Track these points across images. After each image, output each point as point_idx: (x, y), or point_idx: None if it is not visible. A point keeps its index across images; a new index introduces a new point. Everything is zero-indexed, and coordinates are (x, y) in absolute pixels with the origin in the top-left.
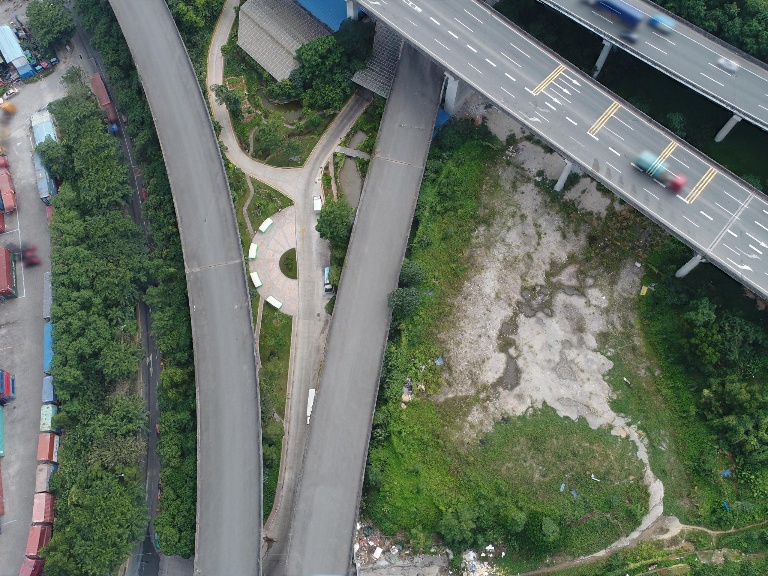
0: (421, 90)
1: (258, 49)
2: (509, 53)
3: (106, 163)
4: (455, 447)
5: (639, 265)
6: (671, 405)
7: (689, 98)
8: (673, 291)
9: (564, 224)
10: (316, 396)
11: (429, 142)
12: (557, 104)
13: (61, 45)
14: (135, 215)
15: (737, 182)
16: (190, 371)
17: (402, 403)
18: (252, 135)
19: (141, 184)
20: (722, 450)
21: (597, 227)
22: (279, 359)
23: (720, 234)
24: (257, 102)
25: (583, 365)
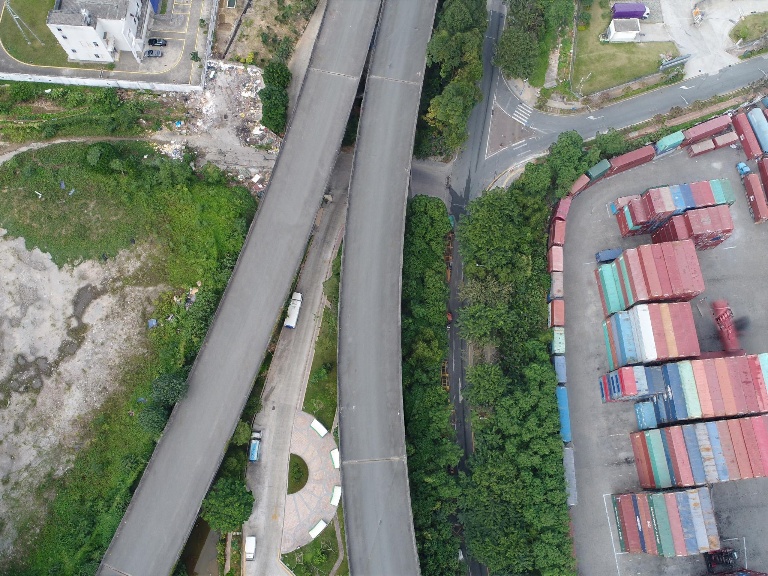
0: None
1: None
2: None
3: None
4: None
5: None
6: None
7: None
8: None
9: None
10: (284, 304)
11: None
12: None
13: None
14: None
15: None
16: (412, 356)
17: None
18: None
19: None
20: None
21: None
22: None
23: None
24: None
25: (8, 299)
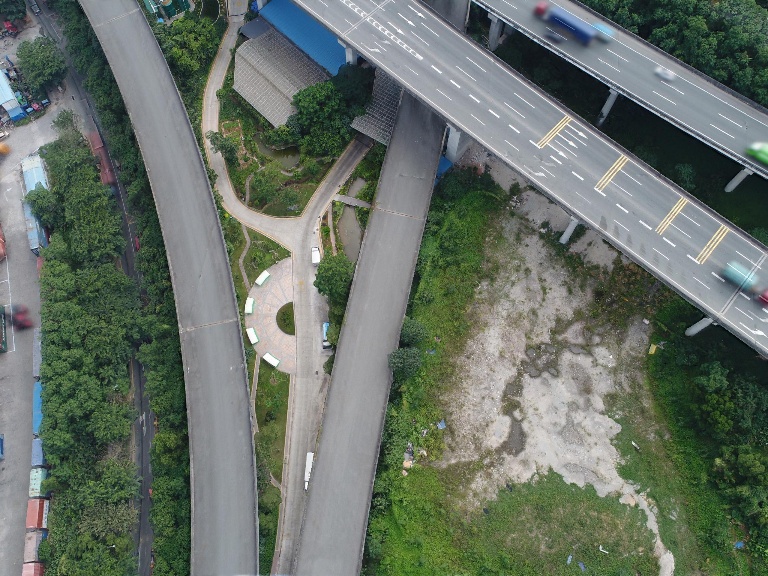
0: (422, 138)
1: (254, 93)
2: (513, 103)
3: (98, 214)
4: (458, 517)
5: (647, 322)
6: (681, 471)
7: (698, 146)
8: (683, 352)
9: (570, 278)
10: (314, 463)
11: (430, 193)
12: (563, 158)
13: (53, 86)
14: (128, 265)
15: (749, 241)
16: (184, 435)
17: (403, 470)
18: (248, 183)
19: (134, 232)
20: (735, 520)
21: (604, 282)
22: (276, 420)
23: (732, 297)
24: (253, 148)
25: (590, 429)
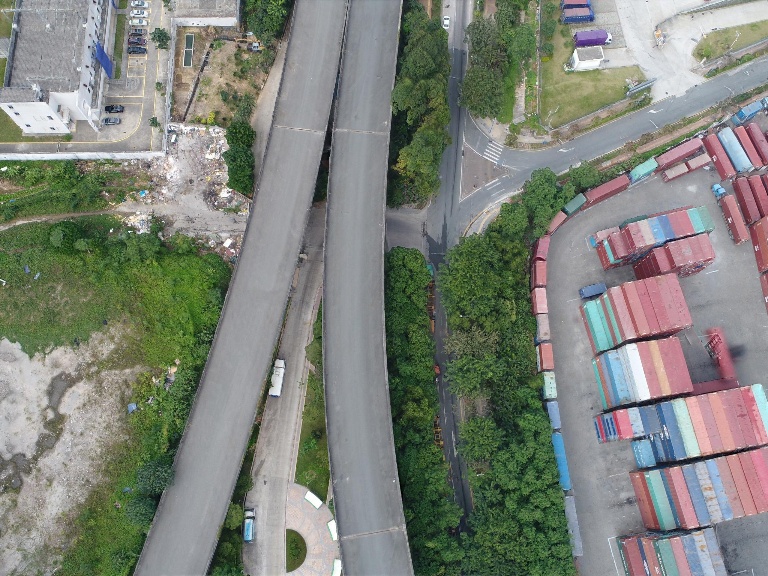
0: None
1: None
2: None
3: None
4: None
5: None
6: None
7: None
8: None
9: None
10: (267, 376)
11: None
12: None
13: None
14: None
15: None
16: (403, 417)
17: None
18: None
19: None
20: None
21: None
22: None
23: None
24: None
25: None
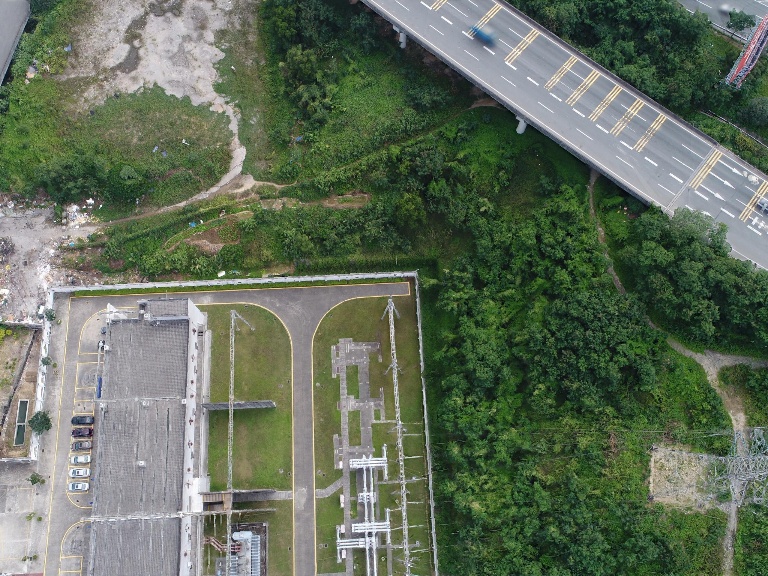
0: None
1: None
2: None
3: None
4: (67, 116)
5: None
6: (267, 87)
7: None
8: None
9: None
10: None
11: None
12: None
13: None
14: None
15: None
16: None
17: (26, 79)
18: None
19: None
20: (300, 121)
21: None
22: None
23: None
24: None
25: (198, 55)
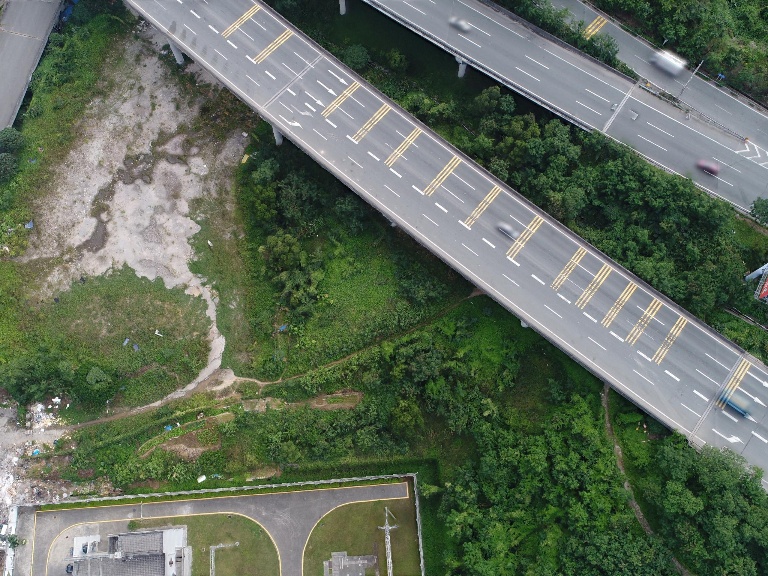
0: None
1: None
2: None
3: None
4: (29, 305)
5: (246, 135)
6: (247, 266)
7: None
8: (260, 156)
9: (180, 96)
10: None
11: (54, 15)
12: None
13: None
14: None
15: (310, 43)
16: None
17: None
18: None
19: None
20: (283, 307)
21: (212, 99)
22: None
23: (279, 93)
24: None
25: (171, 229)
